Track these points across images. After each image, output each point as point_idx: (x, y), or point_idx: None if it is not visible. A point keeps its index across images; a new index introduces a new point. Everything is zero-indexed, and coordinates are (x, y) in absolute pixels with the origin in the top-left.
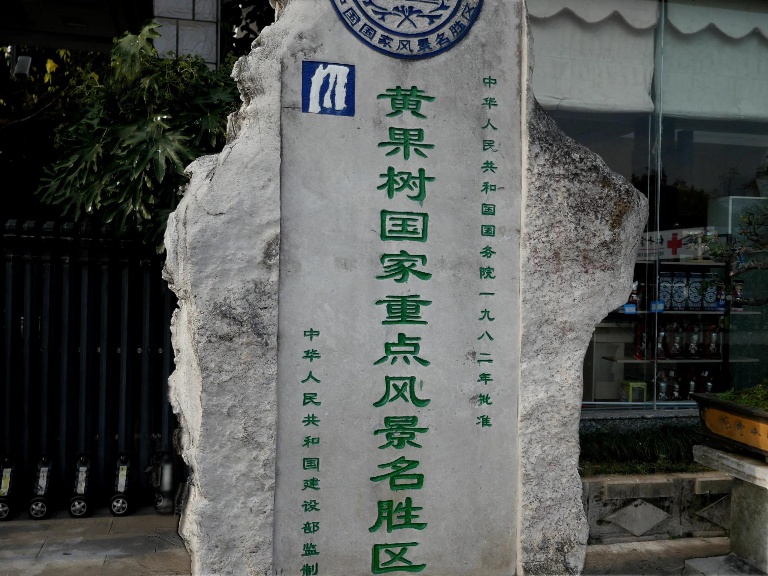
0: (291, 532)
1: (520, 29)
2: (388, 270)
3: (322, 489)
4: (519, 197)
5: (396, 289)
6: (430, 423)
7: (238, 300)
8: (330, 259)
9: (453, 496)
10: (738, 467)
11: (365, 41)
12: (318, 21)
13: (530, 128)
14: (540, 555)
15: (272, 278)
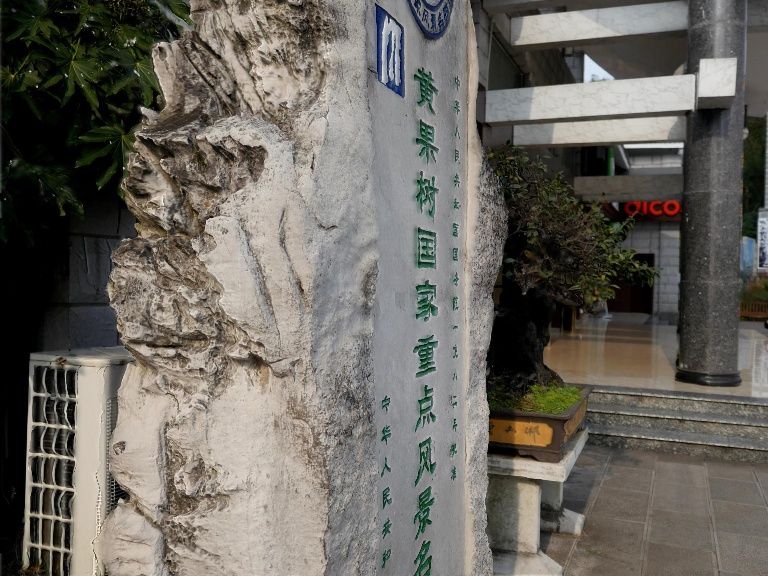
0: None
1: (467, 29)
2: (421, 306)
3: None
4: (466, 217)
5: (425, 330)
6: (435, 490)
7: (356, 368)
8: (393, 295)
9: (442, 570)
10: (493, 464)
11: None
12: None
13: None
14: None
15: (370, 328)
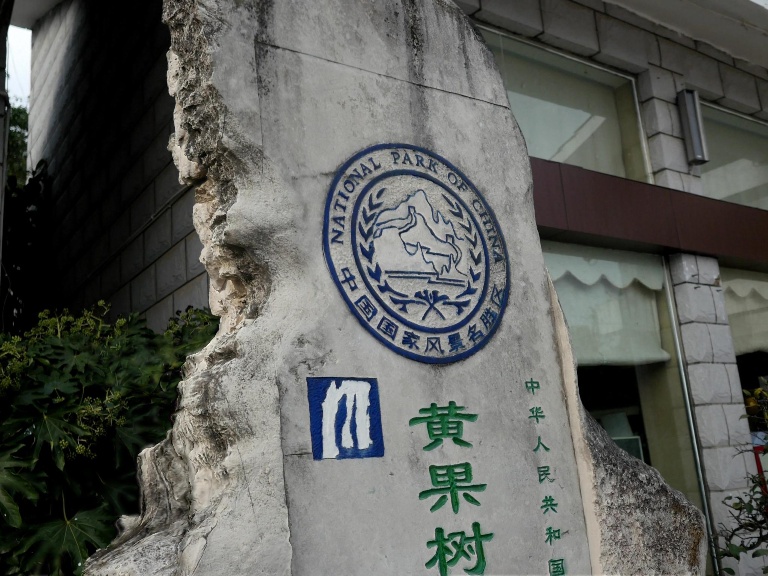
0: None
1: (552, 315)
2: None
3: None
4: (585, 541)
5: None
6: None
7: None
8: None
9: None
10: None
11: (386, 342)
12: (323, 316)
13: (590, 445)
14: None
15: None
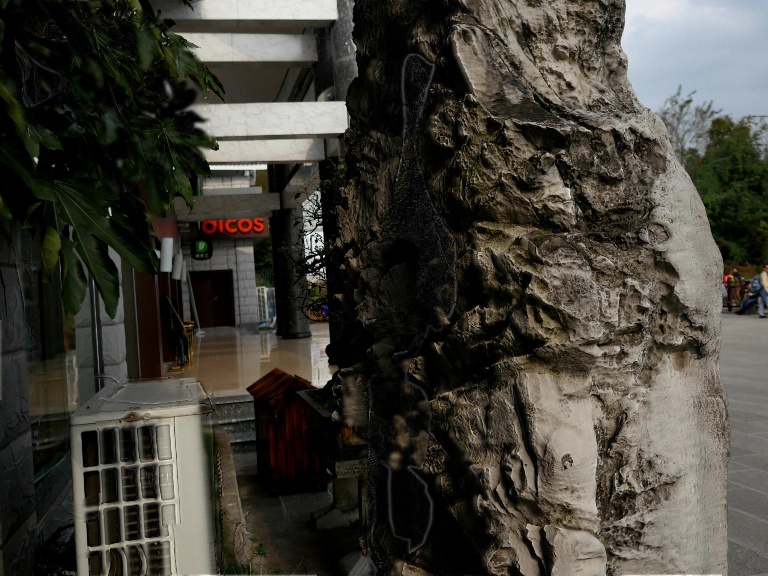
0: None
1: None
2: None
3: None
4: None
5: None
6: None
7: None
8: None
9: None
10: None
11: None
12: None
13: None
14: None
15: None
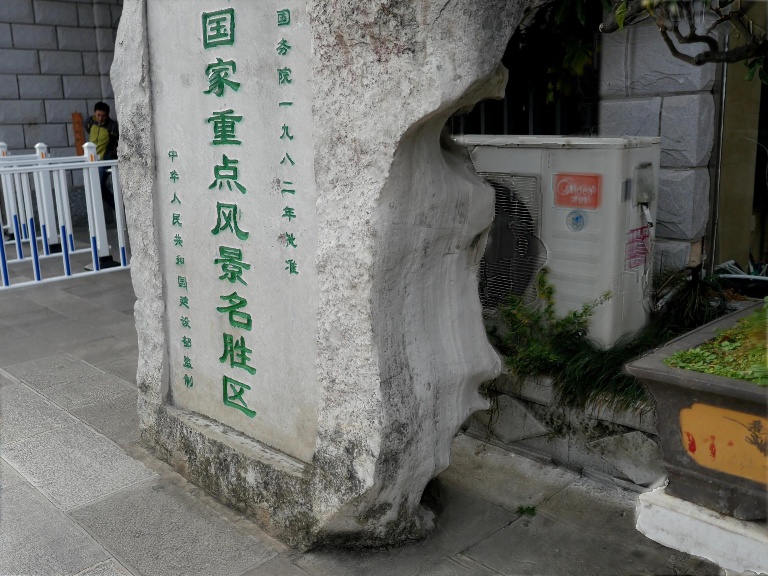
0: (176, 341)
1: None
2: None
3: (190, 308)
4: None
5: (217, 104)
6: (251, 259)
7: (129, 122)
8: (178, 76)
9: (273, 347)
10: None
11: None
12: None
13: None
14: (332, 448)
15: (146, 100)
